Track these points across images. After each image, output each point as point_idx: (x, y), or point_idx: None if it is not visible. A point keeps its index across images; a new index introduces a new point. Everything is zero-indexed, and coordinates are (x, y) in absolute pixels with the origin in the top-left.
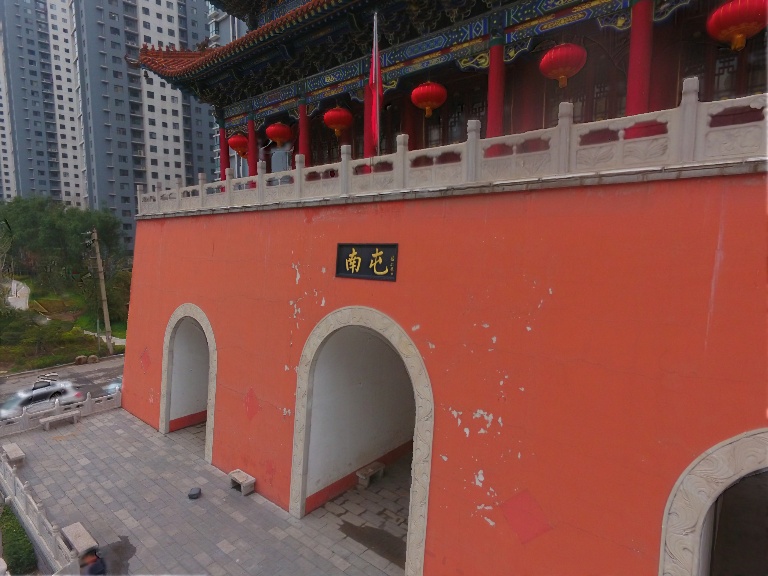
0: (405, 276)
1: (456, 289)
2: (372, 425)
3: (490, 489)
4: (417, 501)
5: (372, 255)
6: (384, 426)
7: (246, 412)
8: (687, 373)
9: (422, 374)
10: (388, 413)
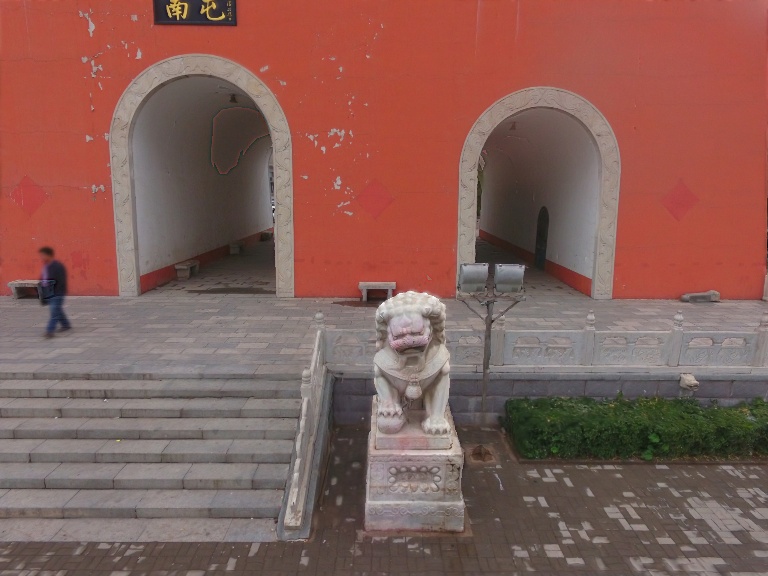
0: (246, 21)
1: (302, 29)
2: (181, 222)
3: (347, 188)
4: (282, 222)
5: (202, 0)
6: (189, 228)
7: (20, 208)
8: (467, 73)
9: (276, 110)
10: (191, 216)
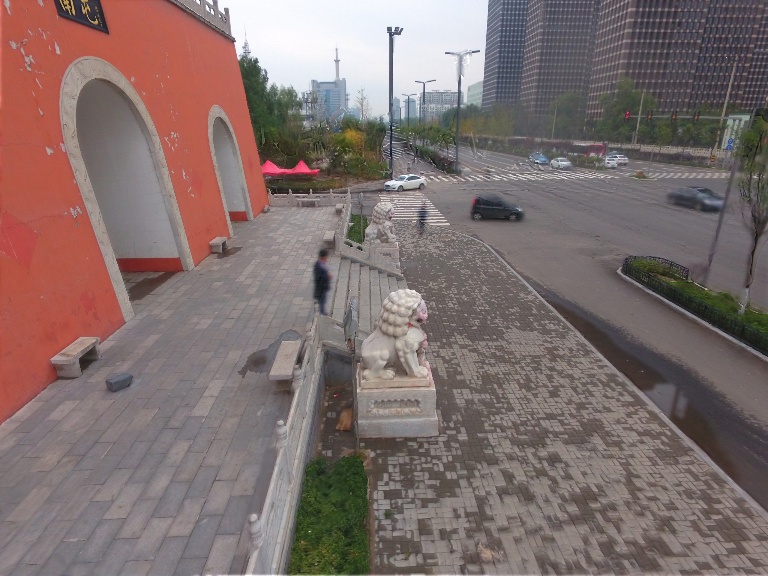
0: None
1: None
2: None
3: None
4: None
5: None
6: None
7: (15, 261)
8: None
9: None
10: None
